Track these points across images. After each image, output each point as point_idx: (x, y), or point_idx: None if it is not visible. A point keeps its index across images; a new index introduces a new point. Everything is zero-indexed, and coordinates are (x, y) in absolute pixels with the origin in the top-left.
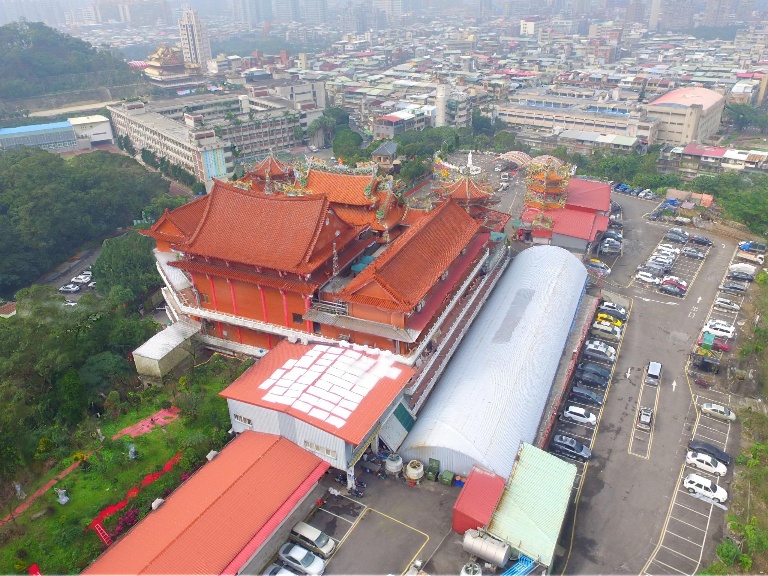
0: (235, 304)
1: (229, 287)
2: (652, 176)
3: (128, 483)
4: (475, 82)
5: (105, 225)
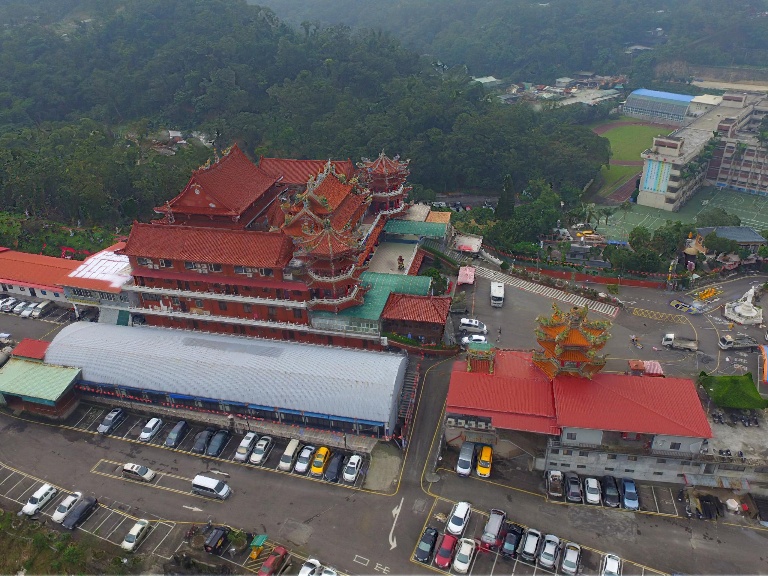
0: None
1: None
2: None
3: (85, 247)
4: None
5: (488, 181)
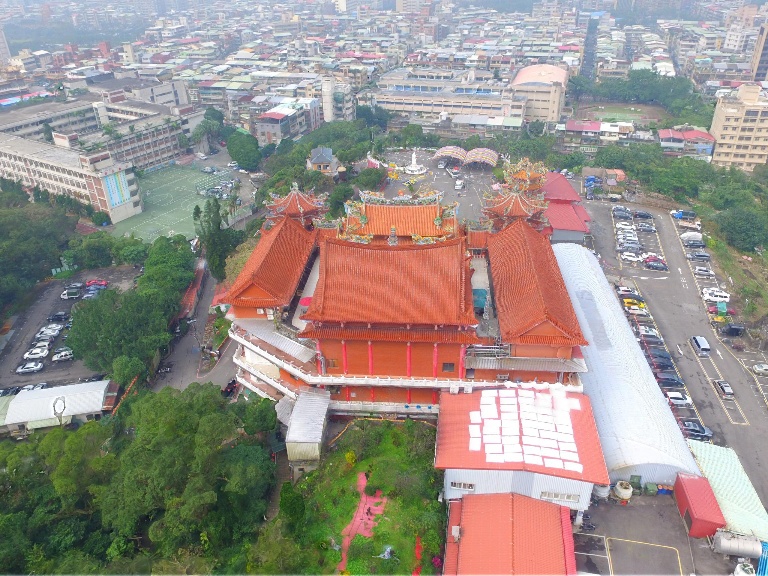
0: (372, 364)
1: (366, 348)
2: (563, 156)
3: None
4: (333, 69)
5: (27, 282)
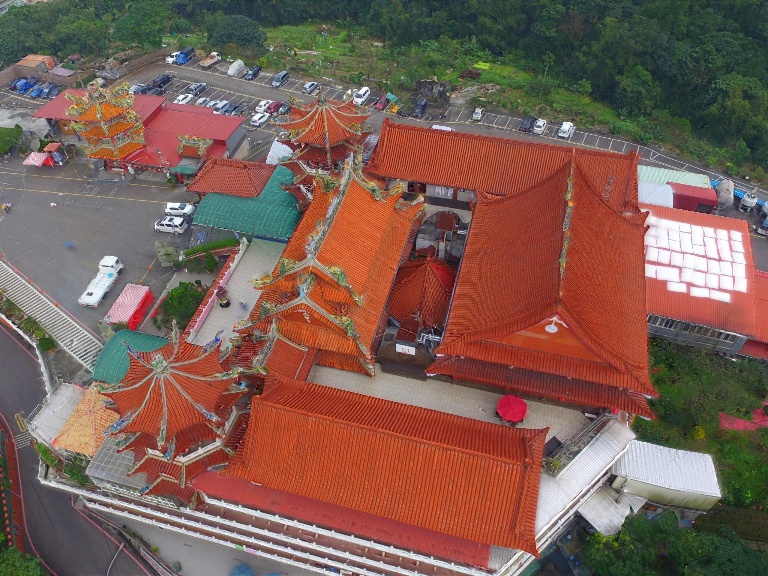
0: None
1: None
2: None
3: None
4: None
5: None
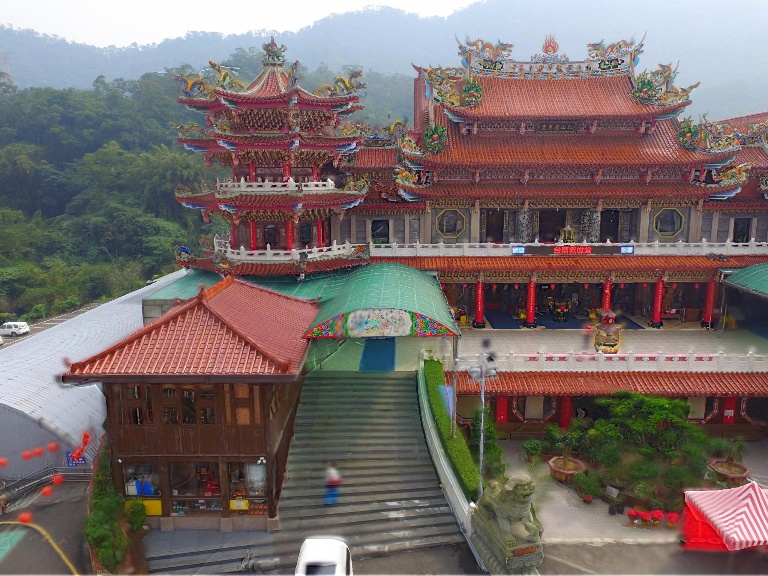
0: None
1: None
2: None
3: None
4: None
5: None
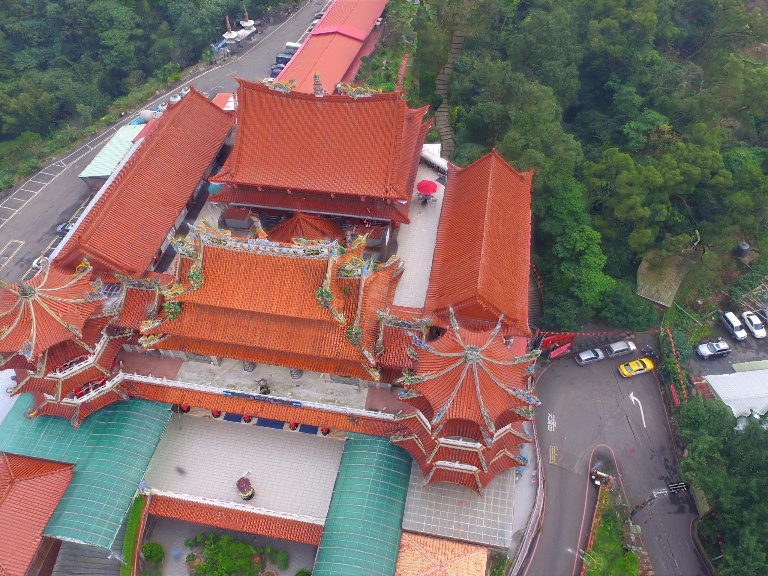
0: None
1: None
2: None
3: None
4: None
5: None
